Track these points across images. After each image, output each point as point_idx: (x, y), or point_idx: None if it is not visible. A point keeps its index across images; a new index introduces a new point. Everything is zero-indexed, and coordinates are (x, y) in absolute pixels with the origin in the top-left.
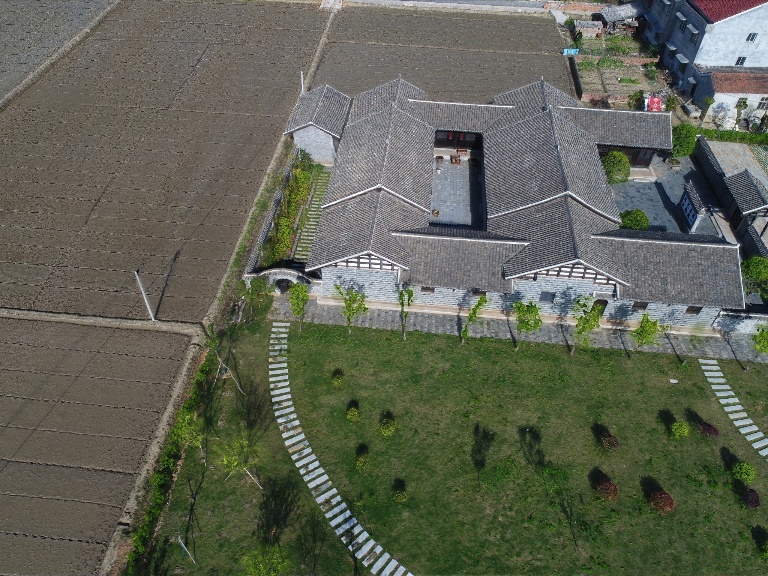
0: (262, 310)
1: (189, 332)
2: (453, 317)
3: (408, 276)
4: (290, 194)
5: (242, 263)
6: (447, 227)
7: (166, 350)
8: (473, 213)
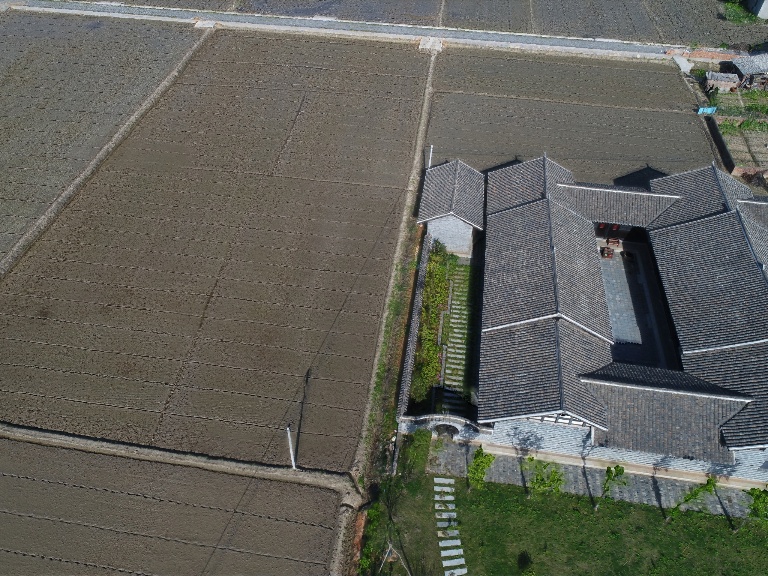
0: (419, 459)
1: (337, 487)
2: (647, 478)
3: (604, 436)
4: (428, 296)
5: (383, 387)
6: (615, 346)
7: (314, 513)
8: (641, 327)
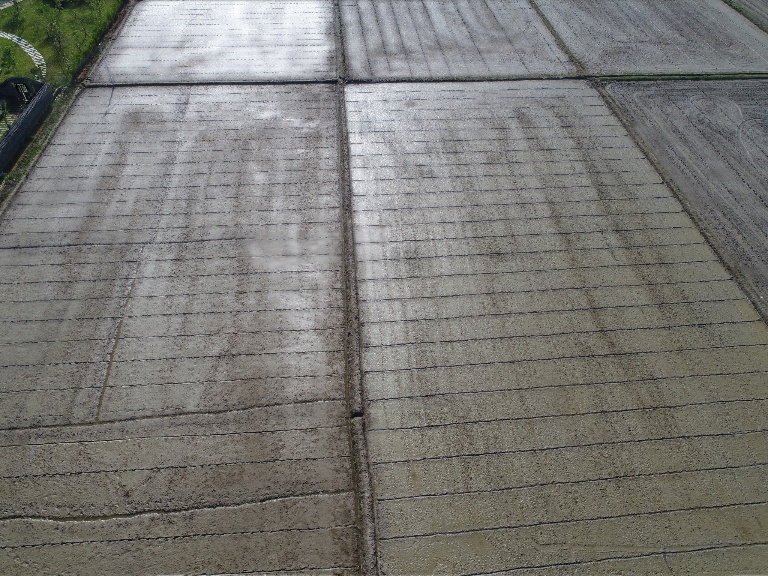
0: None
1: None
2: None
3: None
4: None
5: None
6: None
7: (104, 77)
8: None
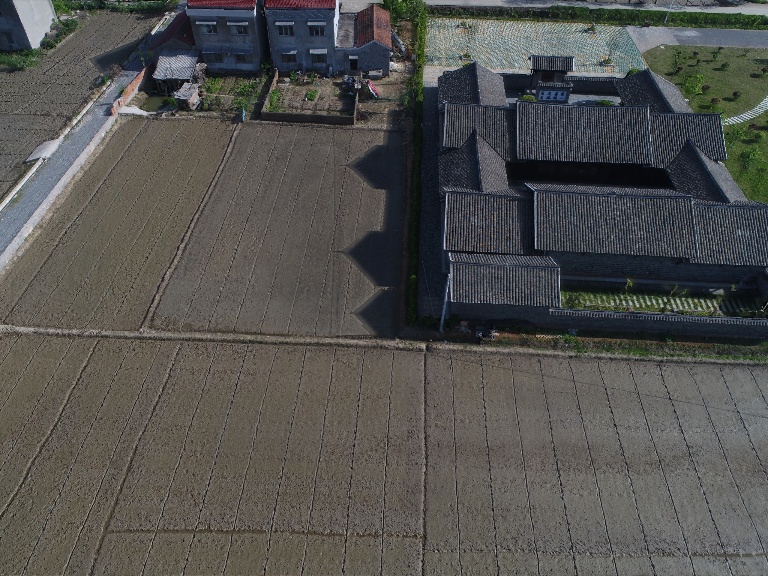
0: None
1: None
2: None
3: None
4: None
5: None
6: None
7: None
8: None
